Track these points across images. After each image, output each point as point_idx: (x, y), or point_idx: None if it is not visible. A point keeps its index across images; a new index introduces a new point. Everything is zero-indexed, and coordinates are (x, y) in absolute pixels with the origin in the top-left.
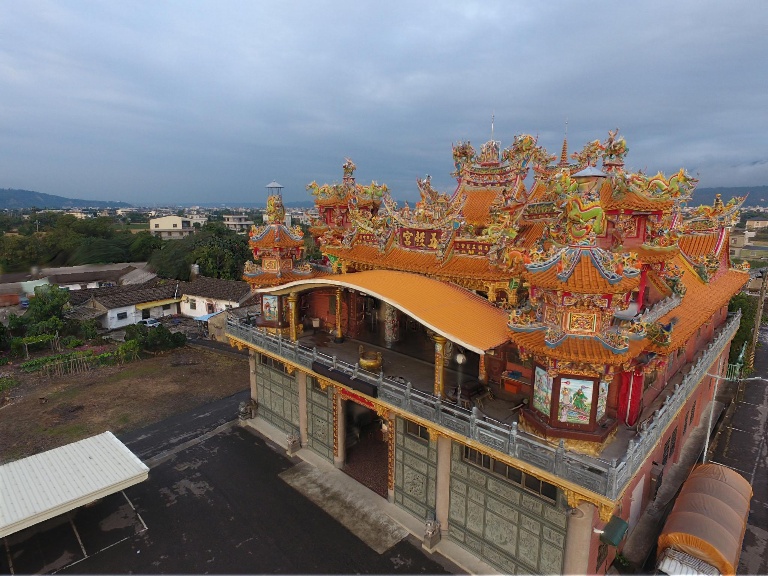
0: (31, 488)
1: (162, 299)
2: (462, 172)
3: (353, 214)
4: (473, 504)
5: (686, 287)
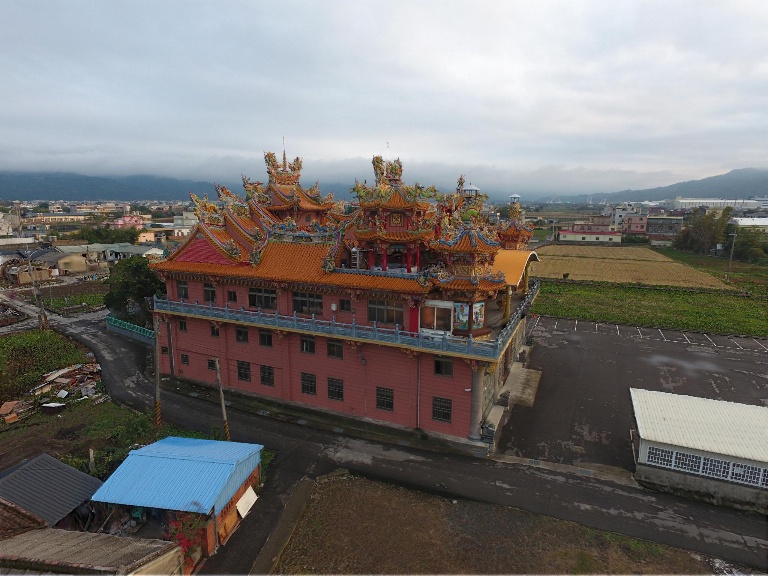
0: (710, 417)
1: None
2: (381, 181)
3: None
4: None
5: None
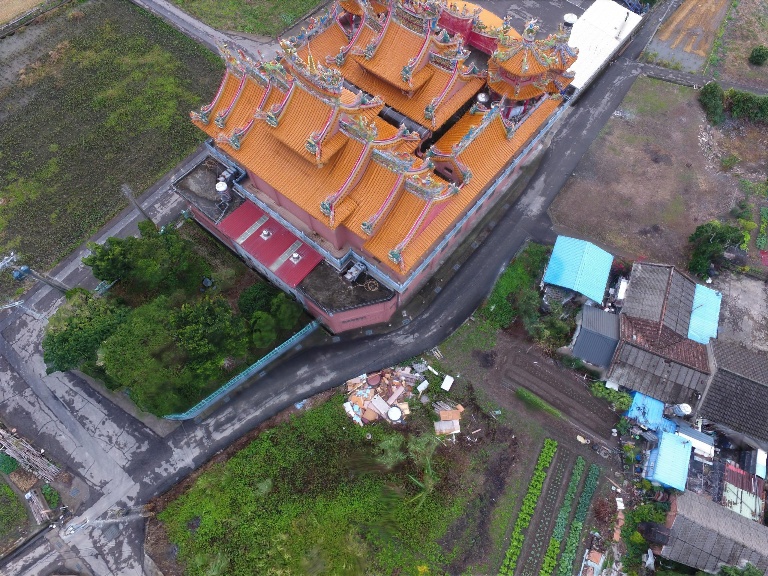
0: None
1: None
2: None
3: None
4: None
5: None
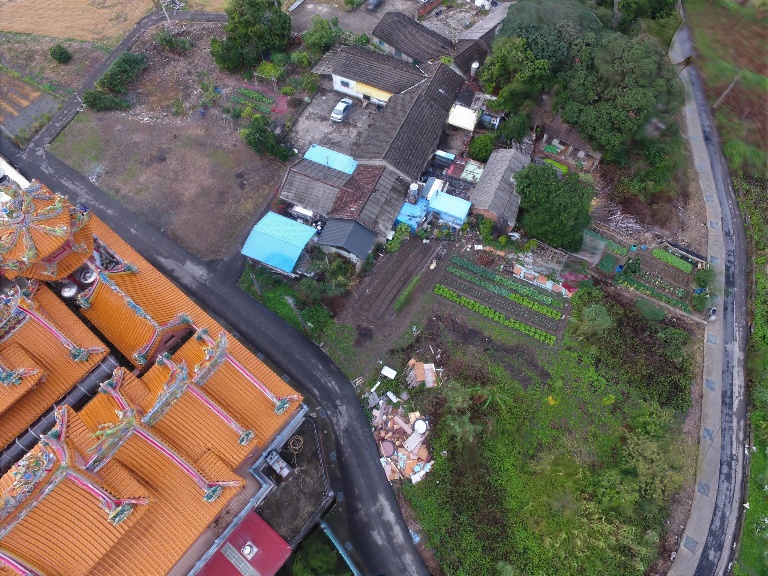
0: None
1: (384, 90)
2: None
3: None
4: None
5: None
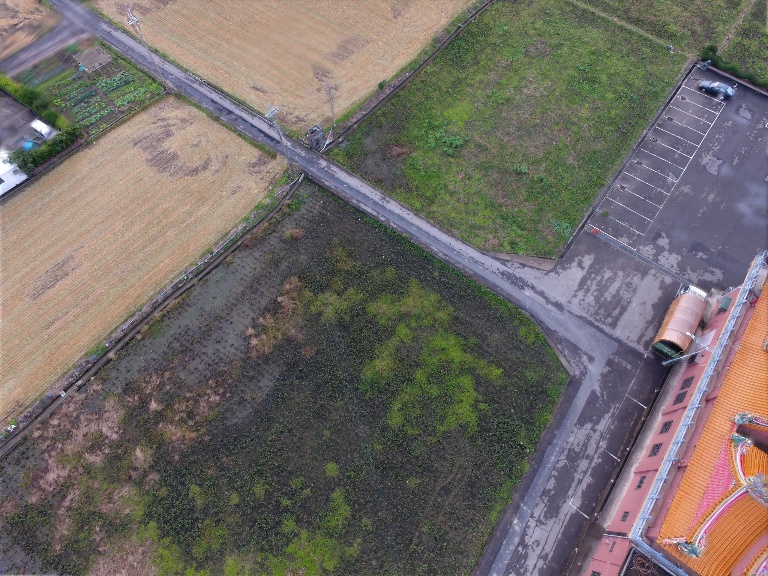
0: None
1: None
2: None
3: None
4: None
5: (759, 382)
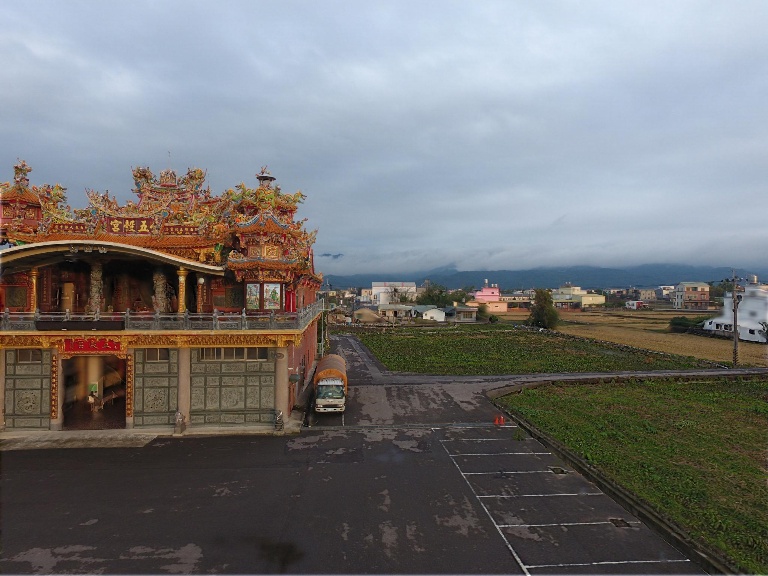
0: None
1: None
2: (143, 189)
3: (46, 206)
4: (211, 389)
5: None
